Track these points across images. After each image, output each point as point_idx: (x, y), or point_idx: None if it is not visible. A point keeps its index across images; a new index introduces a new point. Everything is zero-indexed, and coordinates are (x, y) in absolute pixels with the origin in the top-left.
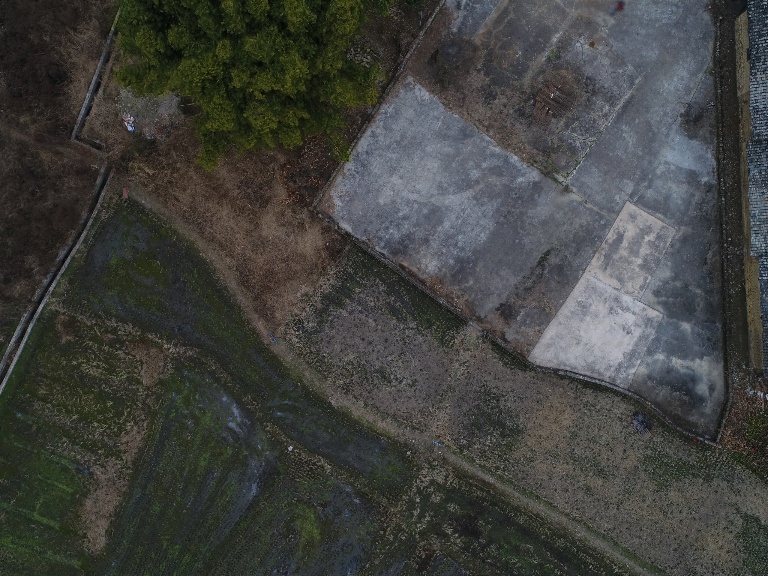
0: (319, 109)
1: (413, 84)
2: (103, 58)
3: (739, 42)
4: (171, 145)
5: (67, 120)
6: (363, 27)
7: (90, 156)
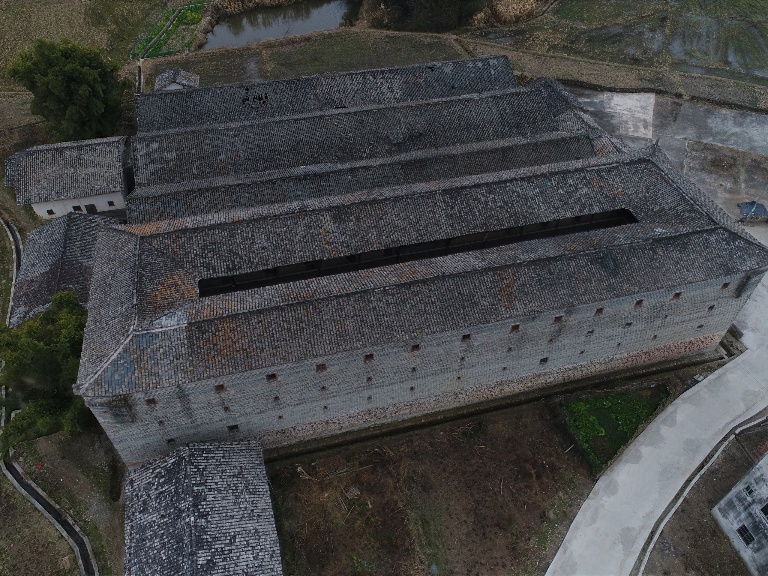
0: None
1: None
2: None
3: None
4: None
5: None
6: None
7: None
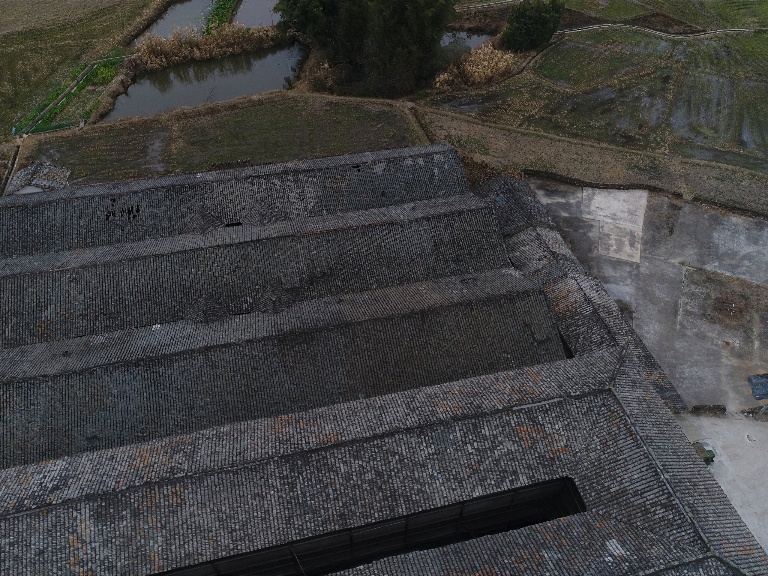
0: None
1: None
2: None
3: None
4: None
5: None
6: None
7: None
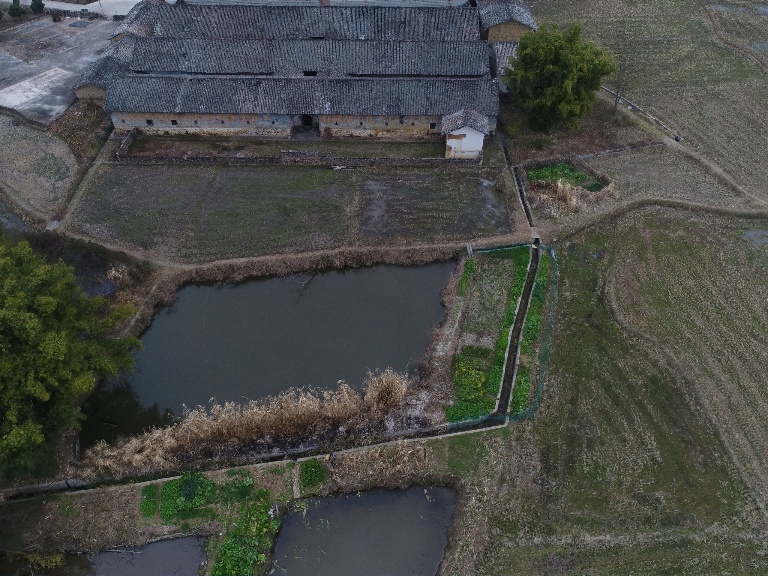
0: None
1: None
2: None
3: None
4: None
5: None
6: None
7: None
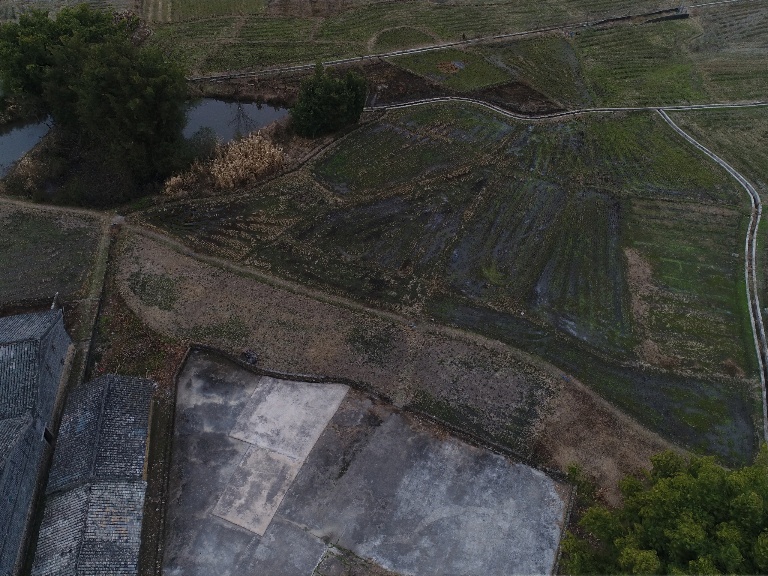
0: None
1: None
2: None
3: None
4: None
5: None
6: None
7: None
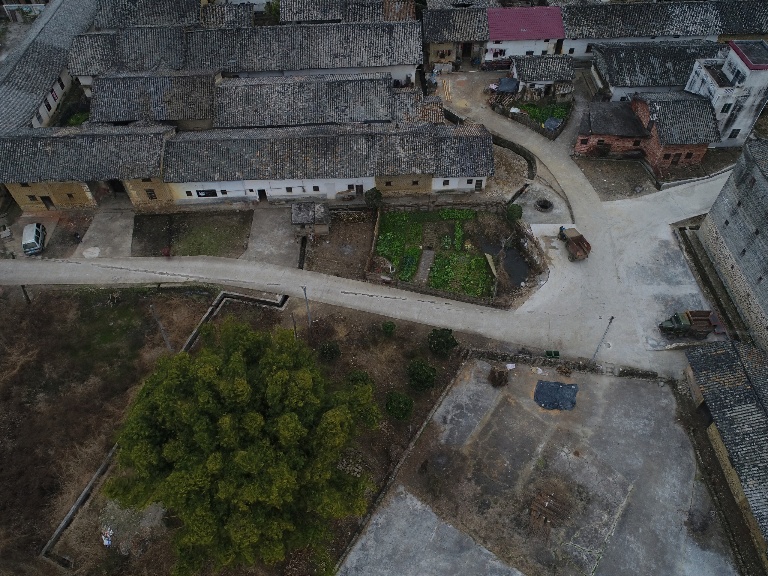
0: (306, 520)
1: (404, 493)
2: (100, 470)
3: (718, 450)
4: (145, 561)
5: (43, 534)
6: (355, 440)
7: (54, 575)
